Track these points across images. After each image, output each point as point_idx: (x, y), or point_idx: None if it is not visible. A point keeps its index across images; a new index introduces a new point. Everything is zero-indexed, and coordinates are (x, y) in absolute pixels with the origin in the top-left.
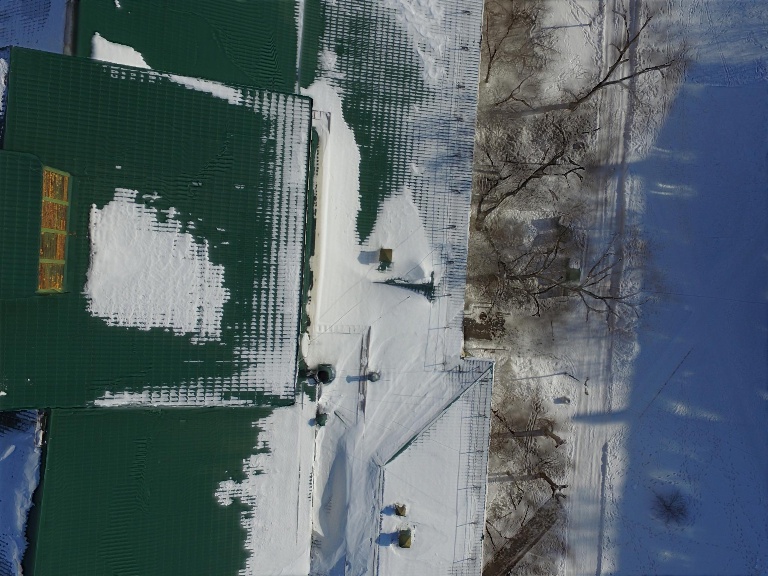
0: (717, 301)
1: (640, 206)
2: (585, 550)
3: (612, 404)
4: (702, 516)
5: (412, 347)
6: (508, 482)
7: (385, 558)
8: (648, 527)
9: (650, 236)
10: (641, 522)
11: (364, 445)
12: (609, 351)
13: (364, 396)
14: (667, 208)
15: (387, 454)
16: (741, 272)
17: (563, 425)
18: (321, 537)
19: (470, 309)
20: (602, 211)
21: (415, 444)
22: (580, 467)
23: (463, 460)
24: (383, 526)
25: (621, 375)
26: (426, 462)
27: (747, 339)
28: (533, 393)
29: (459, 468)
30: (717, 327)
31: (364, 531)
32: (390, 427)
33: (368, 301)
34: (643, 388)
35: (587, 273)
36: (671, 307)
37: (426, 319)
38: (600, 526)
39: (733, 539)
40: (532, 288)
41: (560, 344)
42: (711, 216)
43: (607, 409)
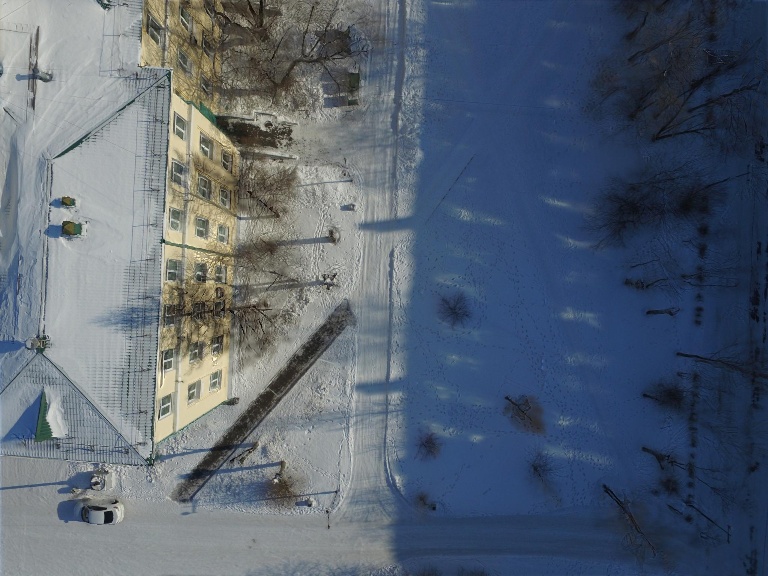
0: (498, 107)
1: (421, 16)
2: (375, 355)
3: (398, 210)
4: (488, 319)
5: (85, 50)
6: (297, 289)
7: (55, 250)
8: (436, 331)
9: (431, 45)
10: (429, 326)
11: (35, 142)
12: (394, 158)
13: (33, 93)
14: (447, 17)
15: (57, 150)
16: (520, 78)
17: (350, 232)
18: (1, 239)
19: (251, 114)
20: (385, 22)
21: (87, 142)
22: (368, 273)
23: (139, 162)
24: (51, 218)
25: (406, 182)
26: (99, 161)
27: (527, 143)
28: (319, 199)
29: (135, 170)
30: (499, 133)
31: (33, 223)
32: (62, 126)
33: (36, 2)
34: (428, 194)
35: (371, 83)
36: (453, 114)
37: (100, 25)
38: (389, 331)
39: (519, 341)
40: (316, 97)
41: (347, 153)
42: (490, 24)
43: (393, 215)
